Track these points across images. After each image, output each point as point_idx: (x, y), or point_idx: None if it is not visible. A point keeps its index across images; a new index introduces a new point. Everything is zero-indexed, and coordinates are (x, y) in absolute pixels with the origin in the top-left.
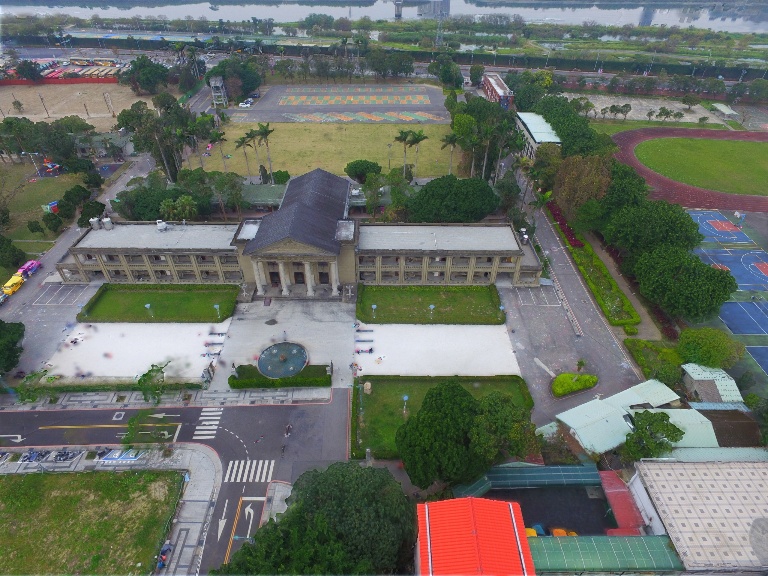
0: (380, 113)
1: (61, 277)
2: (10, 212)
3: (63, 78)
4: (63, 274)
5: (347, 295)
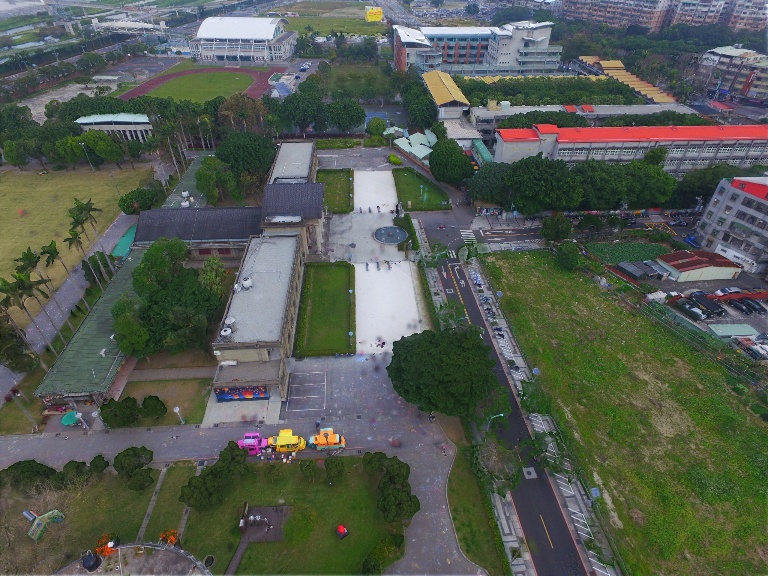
0: None
1: None
2: None
3: None
4: None
5: (327, 215)
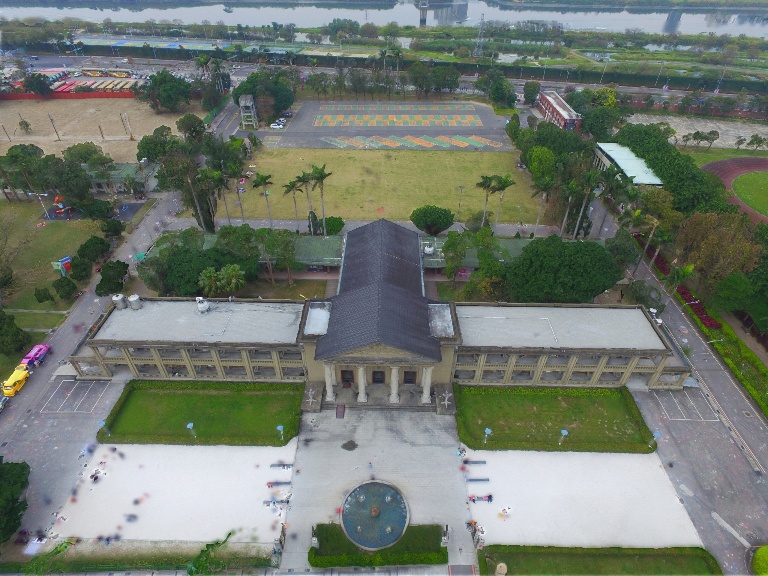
0: (430, 137)
1: (76, 370)
2: (14, 269)
3: (74, 92)
4: (79, 367)
5: (442, 403)
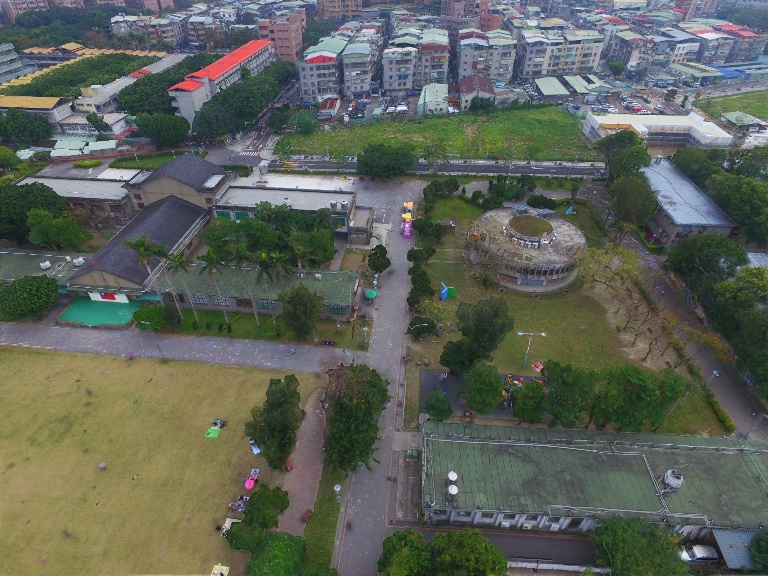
0: None
1: None
2: None
3: None
4: None
5: None
